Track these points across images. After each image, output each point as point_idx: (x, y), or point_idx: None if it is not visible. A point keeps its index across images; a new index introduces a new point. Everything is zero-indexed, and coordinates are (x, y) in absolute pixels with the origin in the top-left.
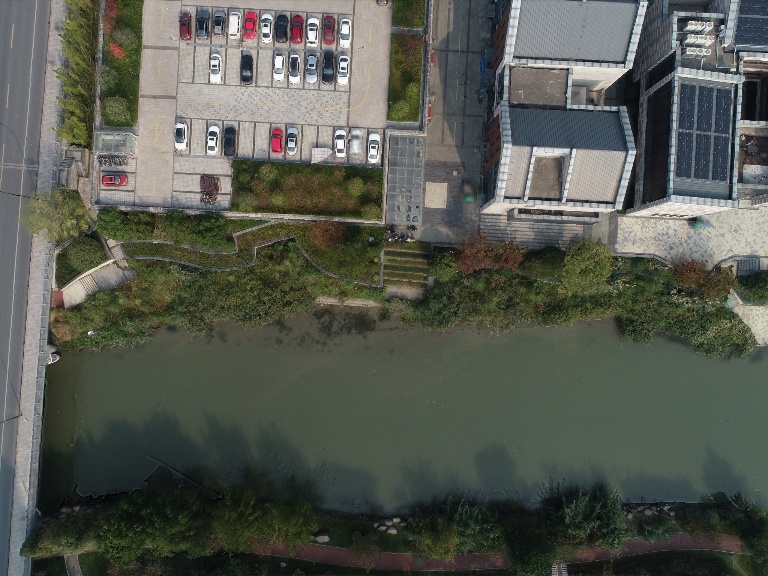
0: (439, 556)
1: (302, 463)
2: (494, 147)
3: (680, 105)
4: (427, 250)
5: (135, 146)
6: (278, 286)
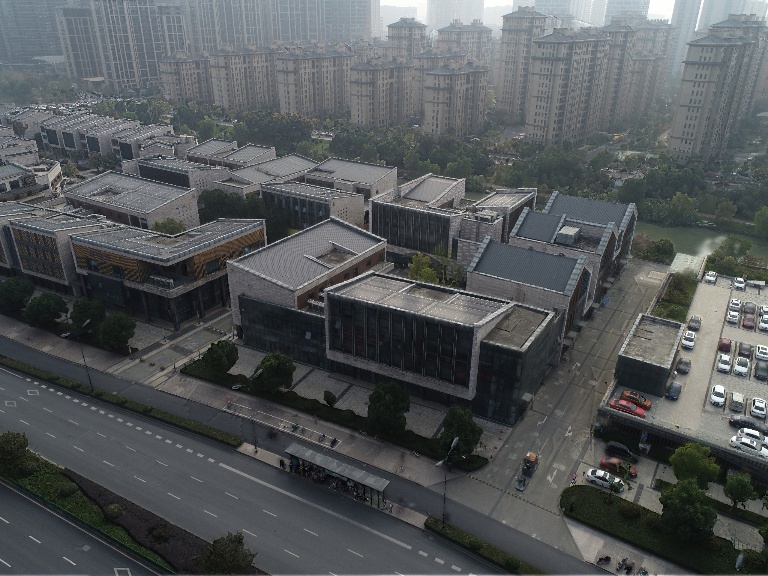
0: (685, 195)
1: (763, 247)
2: None
3: (512, 205)
4: None
5: None
6: None
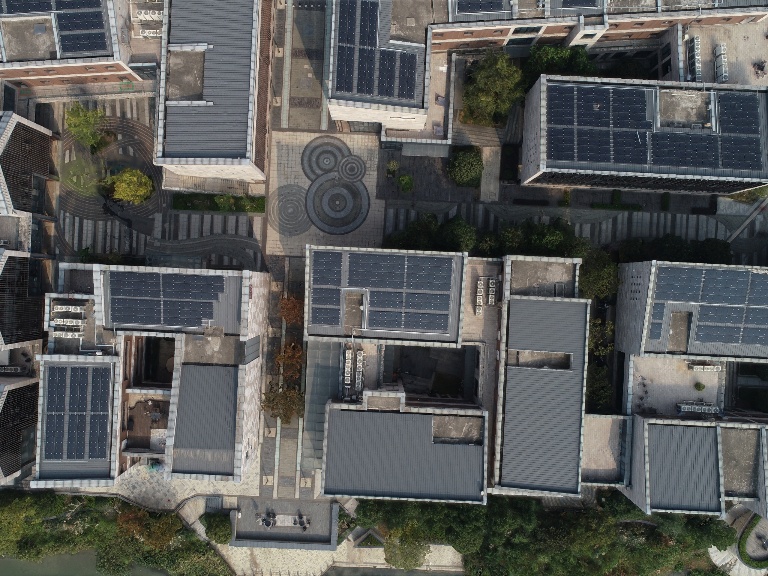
0: None
1: None
2: None
3: (48, 388)
4: None
5: None
6: None
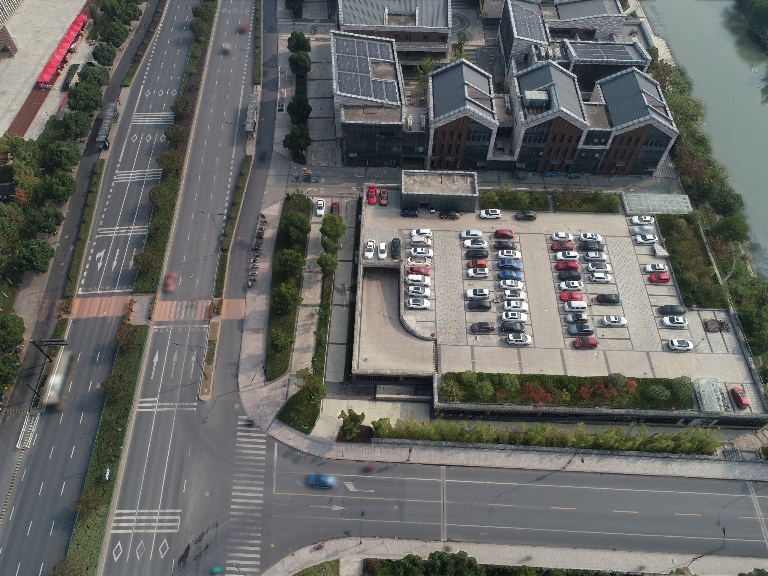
0: None
1: None
2: (630, 148)
3: None
4: (693, 204)
5: (702, 383)
6: (759, 297)
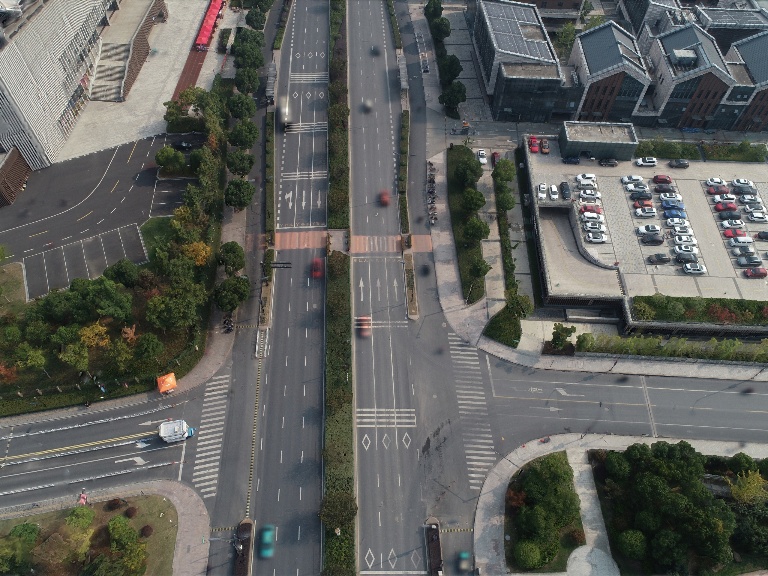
0: None
1: None
2: None
3: None
4: None
5: None
6: None
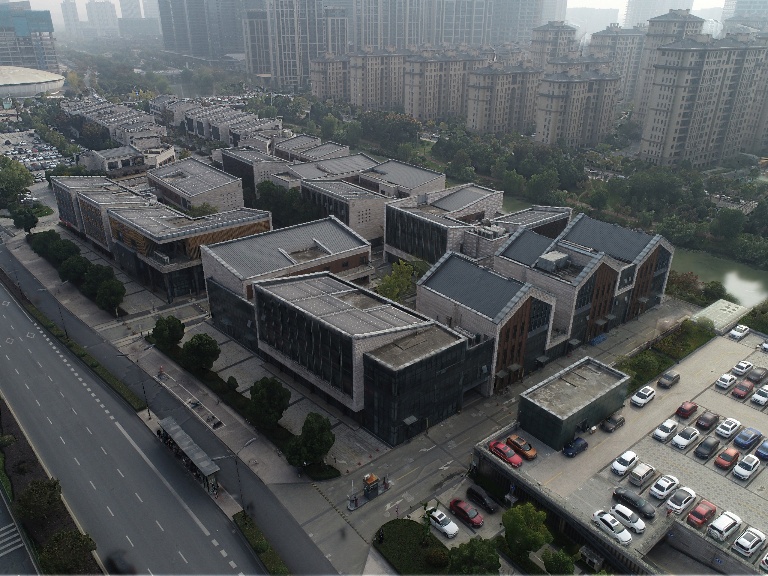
0: None
1: None
2: None
3: None
4: None
5: None
6: None
